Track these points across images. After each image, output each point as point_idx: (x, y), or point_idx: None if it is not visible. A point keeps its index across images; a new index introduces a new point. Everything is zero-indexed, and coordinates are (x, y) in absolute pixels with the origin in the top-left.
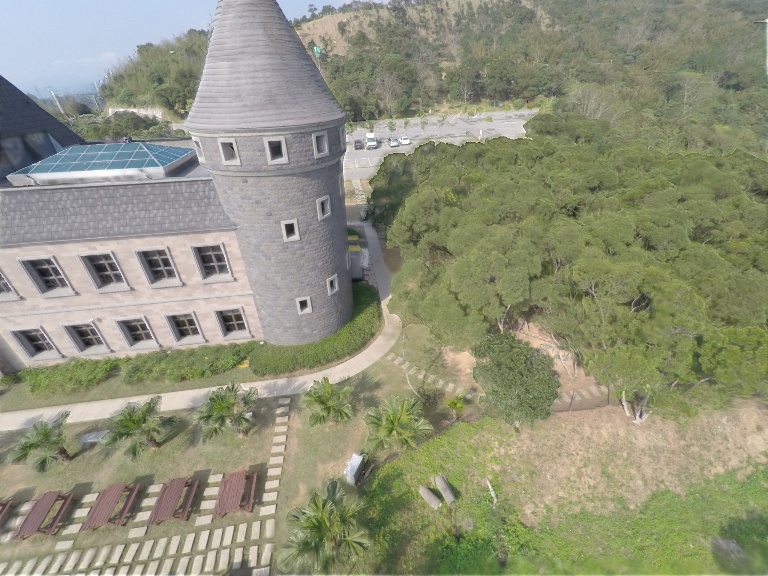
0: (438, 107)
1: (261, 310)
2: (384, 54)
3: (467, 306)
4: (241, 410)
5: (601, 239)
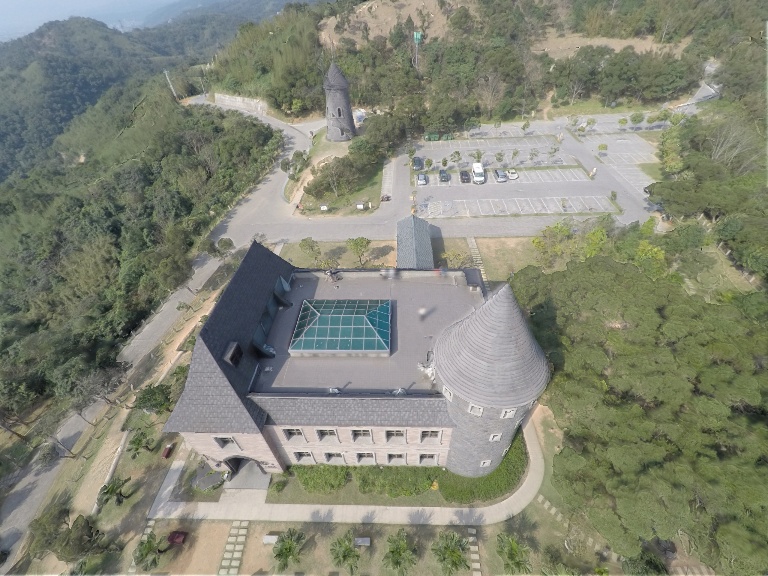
0: (541, 104)
1: (452, 457)
2: (488, 39)
3: (628, 529)
4: (463, 557)
5: (742, 501)
